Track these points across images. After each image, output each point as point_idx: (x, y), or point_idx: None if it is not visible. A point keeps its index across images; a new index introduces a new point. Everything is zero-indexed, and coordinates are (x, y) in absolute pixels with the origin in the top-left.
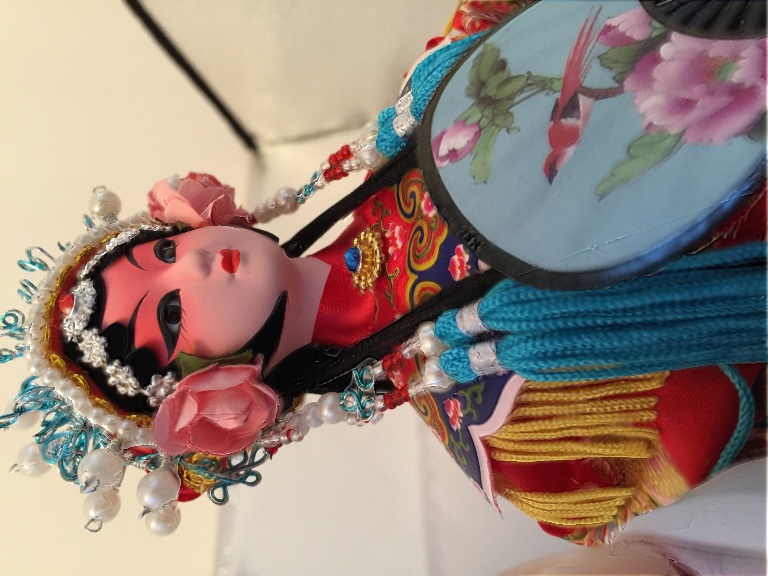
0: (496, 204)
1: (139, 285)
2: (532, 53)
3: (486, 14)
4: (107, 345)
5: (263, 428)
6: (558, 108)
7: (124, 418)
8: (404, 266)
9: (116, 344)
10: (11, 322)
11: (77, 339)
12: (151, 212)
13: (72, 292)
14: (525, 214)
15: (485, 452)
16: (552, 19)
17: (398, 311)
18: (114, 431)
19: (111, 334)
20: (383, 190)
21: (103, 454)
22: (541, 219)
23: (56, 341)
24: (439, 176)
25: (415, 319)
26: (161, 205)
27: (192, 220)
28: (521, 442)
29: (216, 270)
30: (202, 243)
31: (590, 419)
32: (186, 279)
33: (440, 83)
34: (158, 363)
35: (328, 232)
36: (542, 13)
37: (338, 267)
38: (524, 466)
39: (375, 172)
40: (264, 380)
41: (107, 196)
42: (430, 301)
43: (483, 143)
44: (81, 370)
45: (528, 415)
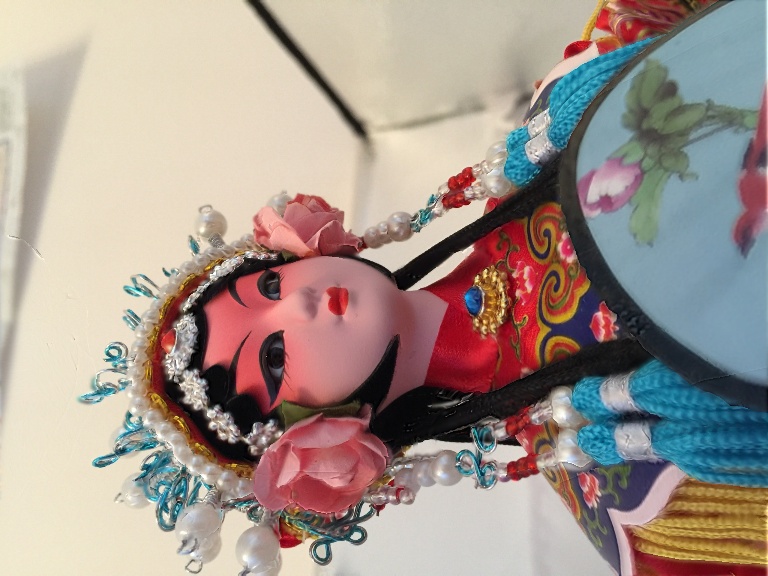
0: (666, 276)
1: (241, 324)
2: (713, 75)
3: (639, 11)
4: (208, 388)
5: (370, 485)
6: (753, 152)
7: (224, 466)
8: (534, 314)
9: (217, 388)
10: (115, 354)
11: (178, 379)
12: (256, 238)
13: (174, 328)
14: (708, 296)
15: (628, 542)
16: (741, 30)
17: (525, 364)
18: (214, 481)
19: (212, 377)
20: (510, 222)
21: (202, 508)
22: (732, 306)
23: (158, 378)
24: (588, 229)
25: (547, 381)
26: (266, 231)
27: (298, 249)
28: (674, 537)
29: (322, 312)
30: (308, 279)
31: (767, 524)
32: (290, 320)
33: (588, 107)
34: (260, 410)
35: (445, 263)
36: (727, 21)
37: (456, 305)
38: (674, 559)
39: (502, 202)
40: (372, 427)
41: (213, 216)
42: (566, 362)
43: (647, 191)
44: (182, 411)
45: (686, 510)
